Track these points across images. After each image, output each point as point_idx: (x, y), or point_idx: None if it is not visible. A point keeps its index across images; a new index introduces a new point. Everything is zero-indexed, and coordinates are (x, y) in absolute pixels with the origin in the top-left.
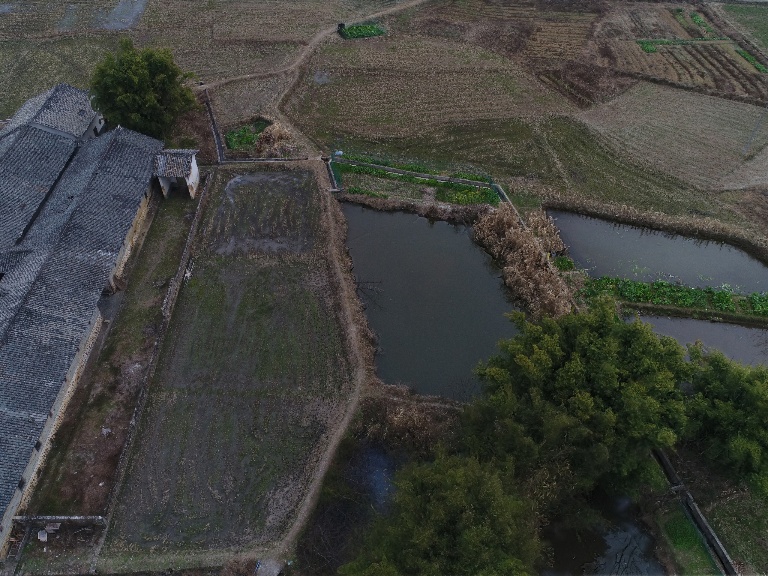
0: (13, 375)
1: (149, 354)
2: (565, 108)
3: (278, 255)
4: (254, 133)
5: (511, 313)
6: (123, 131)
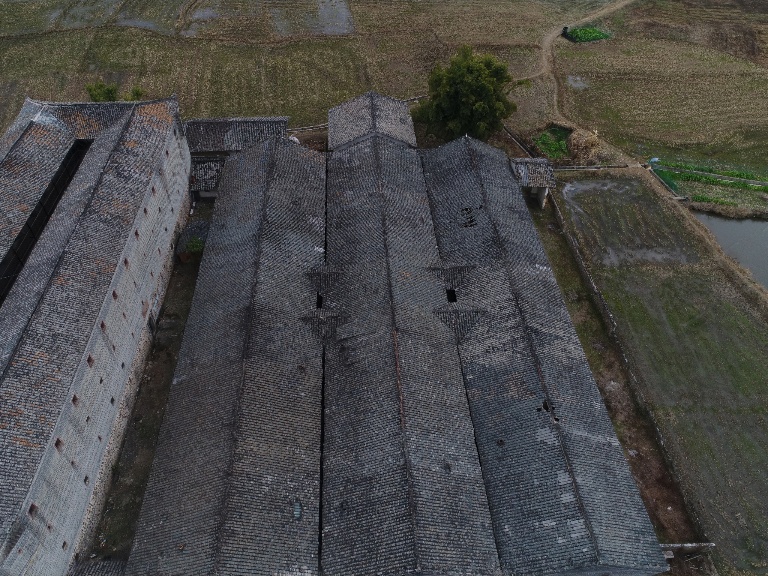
0: (568, 397)
1: (617, 371)
2: None
3: (669, 266)
4: (555, 140)
5: None
6: (472, 140)
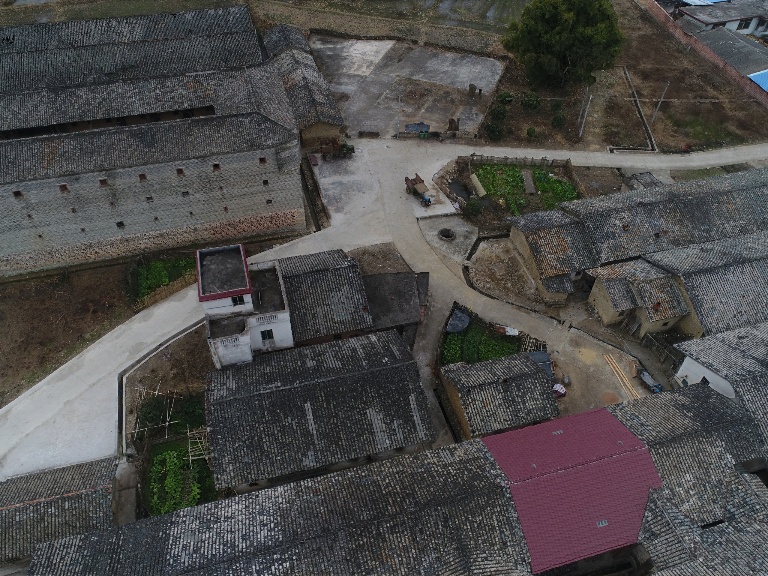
0: None
1: None
2: None
3: None
4: None
5: None
6: None
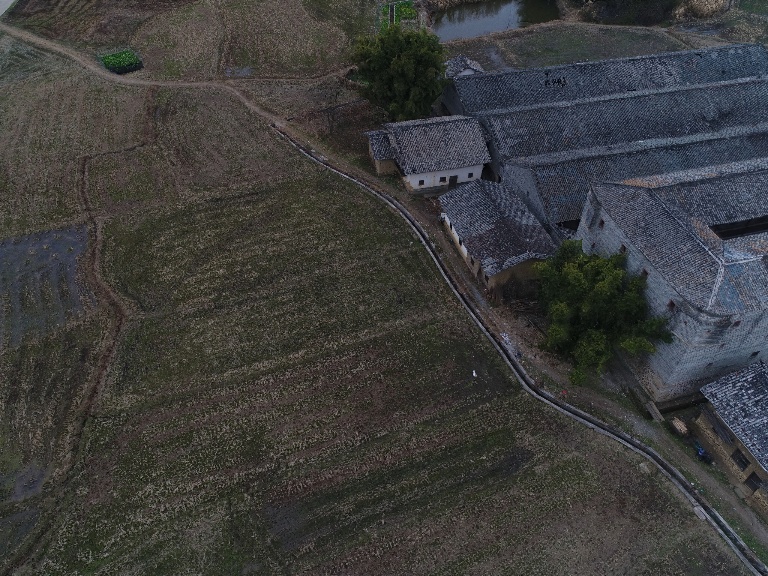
0: None
1: None
2: None
3: None
4: None
5: None
6: None
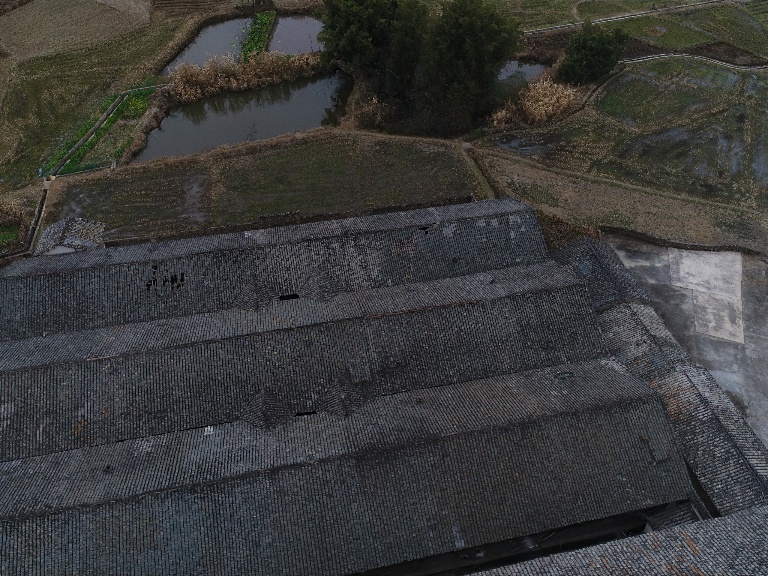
0: None
1: None
2: (3, 62)
3: None
4: None
5: (319, 39)
6: (0, 276)
